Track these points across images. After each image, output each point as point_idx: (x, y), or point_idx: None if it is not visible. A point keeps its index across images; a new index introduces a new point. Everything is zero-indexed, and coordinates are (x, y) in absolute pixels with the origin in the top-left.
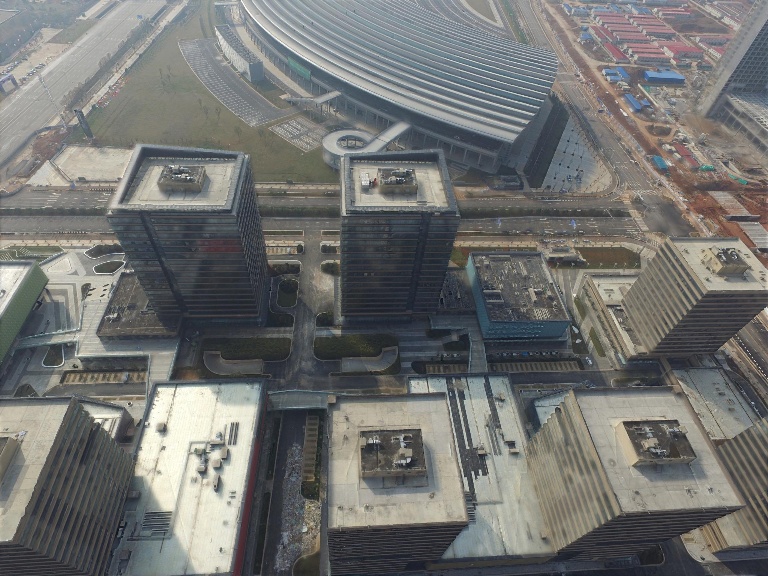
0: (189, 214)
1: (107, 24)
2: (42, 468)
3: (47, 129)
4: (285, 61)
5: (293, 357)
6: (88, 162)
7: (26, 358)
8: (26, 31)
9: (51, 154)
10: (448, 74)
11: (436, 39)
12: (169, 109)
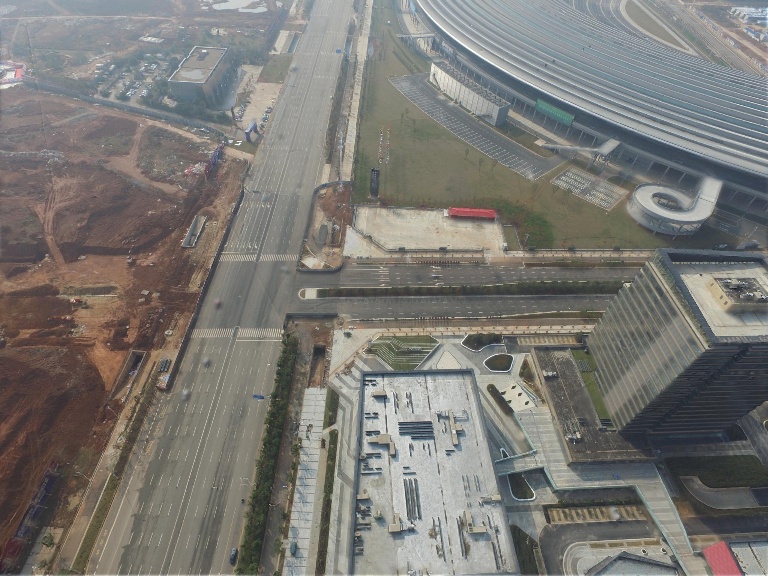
0: None
1: (304, 59)
2: None
3: (323, 186)
4: (530, 103)
5: None
6: (391, 227)
7: None
8: (231, 69)
9: (347, 218)
10: (751, 123)
11: (706, 80)
12: (434, 160)
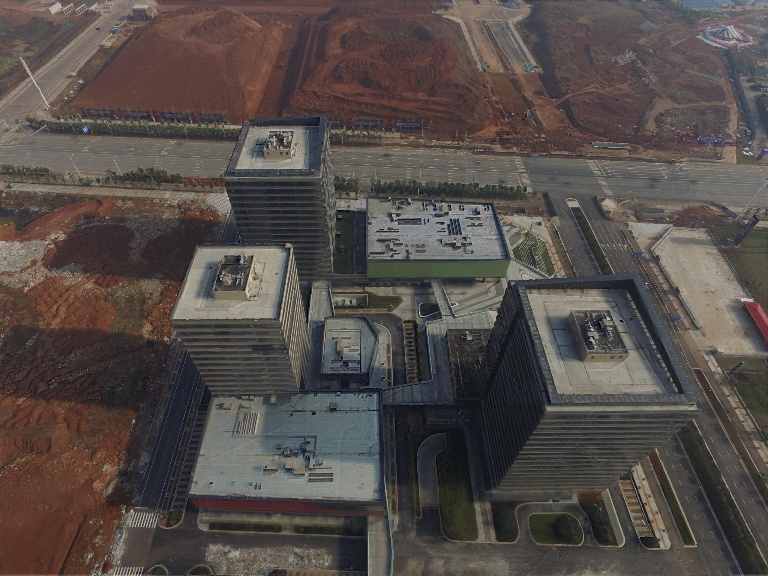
0: (532, 357)
1: None
2: (220, 319)
3: (722, 208)
4: None
5: (449, 546)
6: (690, 255)
7: (426, 291)
8: None
9: (683, 224)
10: None
11: None
12: None
